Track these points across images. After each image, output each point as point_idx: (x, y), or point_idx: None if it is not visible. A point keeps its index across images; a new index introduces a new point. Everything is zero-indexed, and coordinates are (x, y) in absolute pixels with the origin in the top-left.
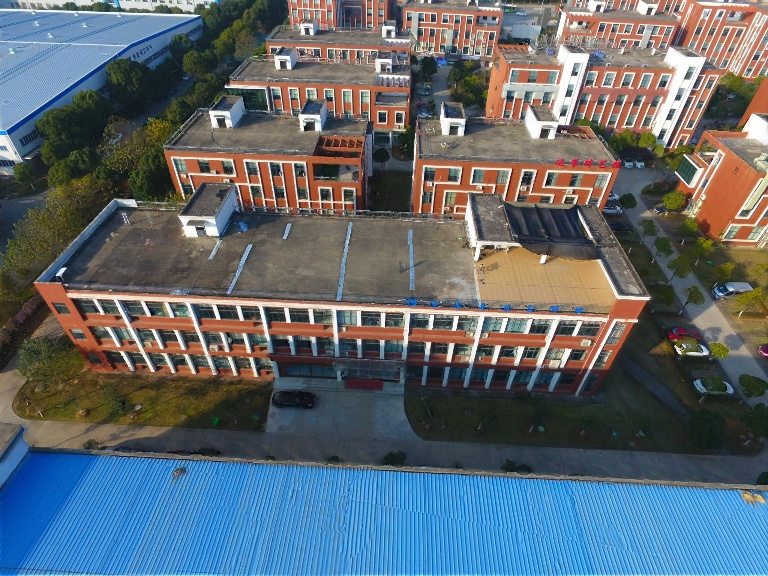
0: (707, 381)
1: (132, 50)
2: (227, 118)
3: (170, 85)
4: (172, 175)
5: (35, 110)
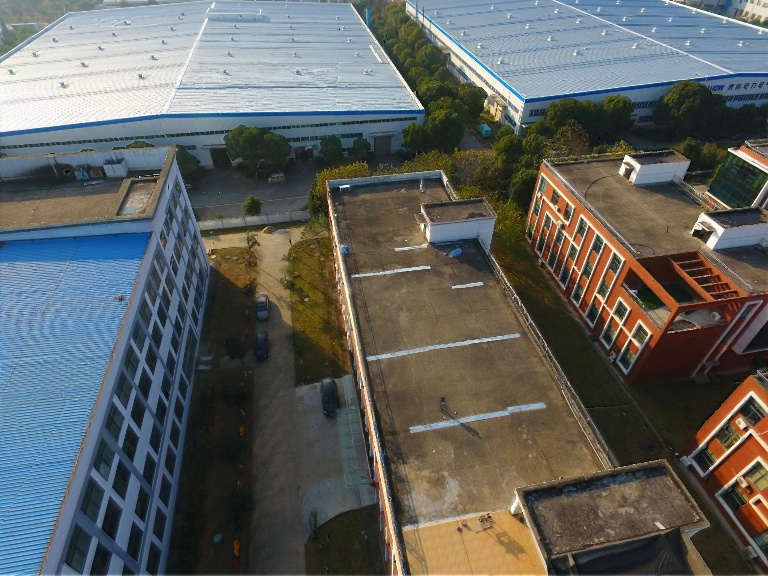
0: None
1: (735, 79)
2: (635, 171)
3: (744, 130)
4: (535, 189)
5: (565, 94)
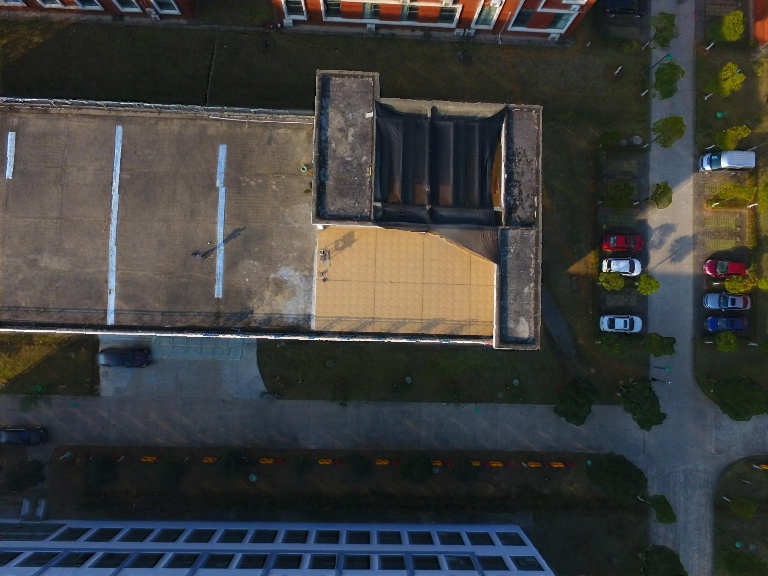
0: (607, 343)
1: None
2: None
3: None
4: None
5: None
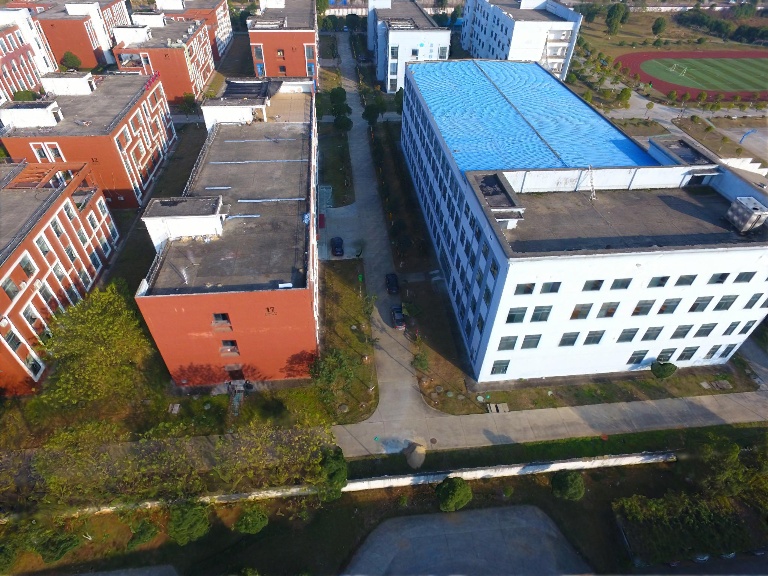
0: (318, 116)
1: None
2: None
3: None
4: None
5: None
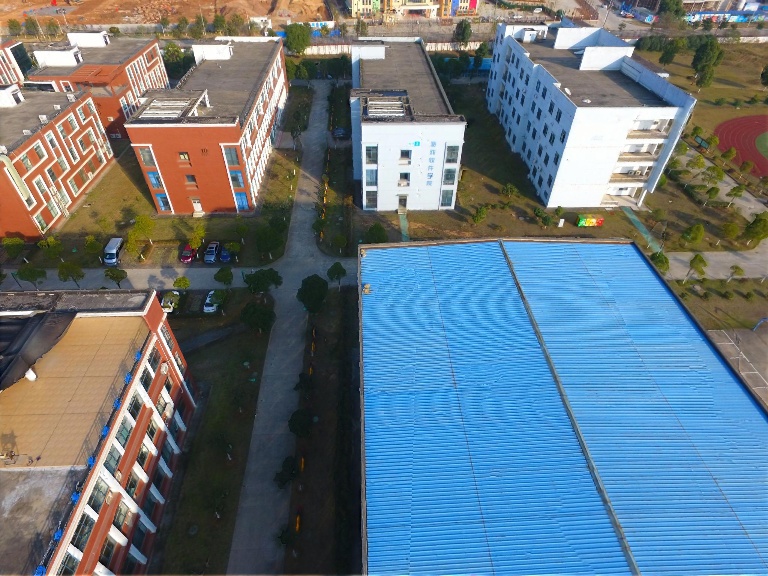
0: (215, 300)
1: None
2: None
3: None
4: None
5: None
